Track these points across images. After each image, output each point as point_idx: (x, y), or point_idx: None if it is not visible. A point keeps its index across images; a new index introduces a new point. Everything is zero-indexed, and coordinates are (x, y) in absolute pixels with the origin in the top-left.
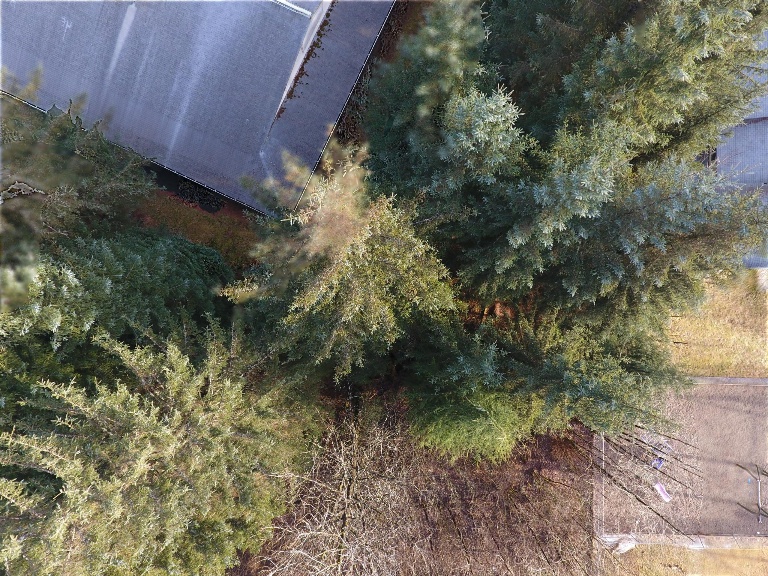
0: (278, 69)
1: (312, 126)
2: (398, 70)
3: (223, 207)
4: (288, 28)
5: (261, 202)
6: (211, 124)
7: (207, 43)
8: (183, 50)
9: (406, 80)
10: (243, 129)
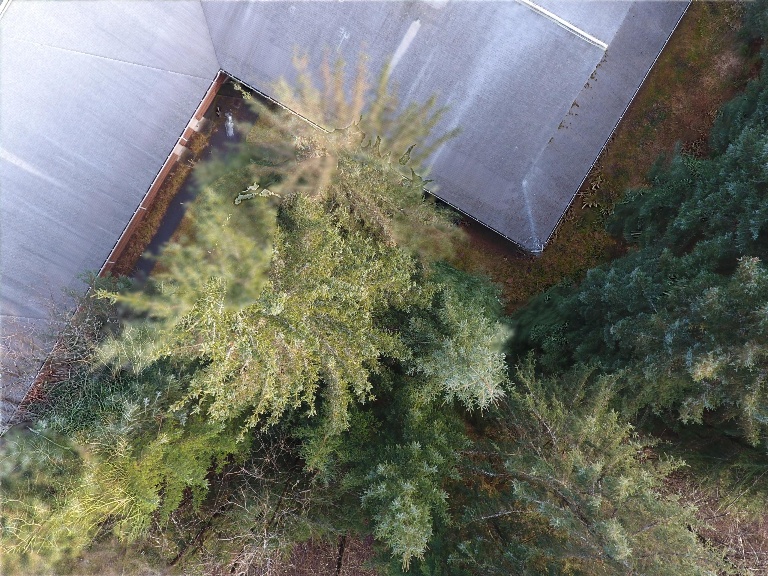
0: (560, 99)
1: (575, 158)
2: (650, 103)
3: (458, 228)
4: (579, 59)
5: (514, 231)
6: (477, 148)
7: (489, 66)
8: (462, 71)
9: (658, 115)
10: (510, 156)
